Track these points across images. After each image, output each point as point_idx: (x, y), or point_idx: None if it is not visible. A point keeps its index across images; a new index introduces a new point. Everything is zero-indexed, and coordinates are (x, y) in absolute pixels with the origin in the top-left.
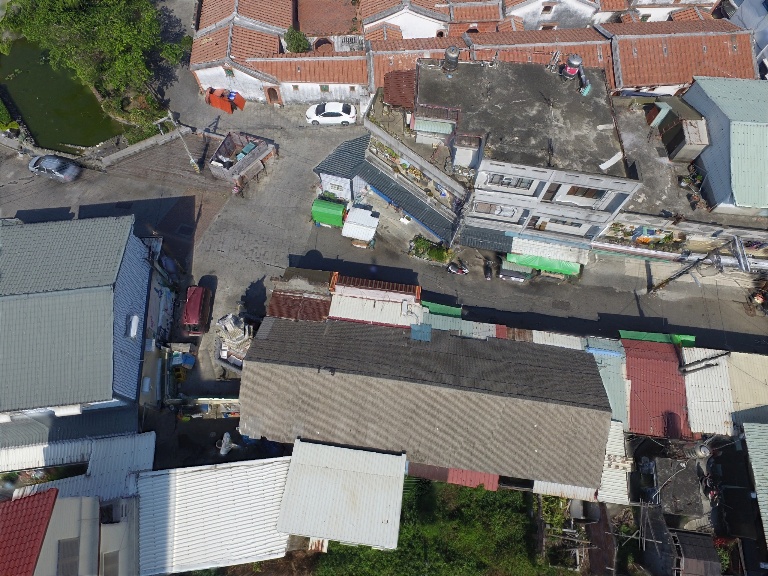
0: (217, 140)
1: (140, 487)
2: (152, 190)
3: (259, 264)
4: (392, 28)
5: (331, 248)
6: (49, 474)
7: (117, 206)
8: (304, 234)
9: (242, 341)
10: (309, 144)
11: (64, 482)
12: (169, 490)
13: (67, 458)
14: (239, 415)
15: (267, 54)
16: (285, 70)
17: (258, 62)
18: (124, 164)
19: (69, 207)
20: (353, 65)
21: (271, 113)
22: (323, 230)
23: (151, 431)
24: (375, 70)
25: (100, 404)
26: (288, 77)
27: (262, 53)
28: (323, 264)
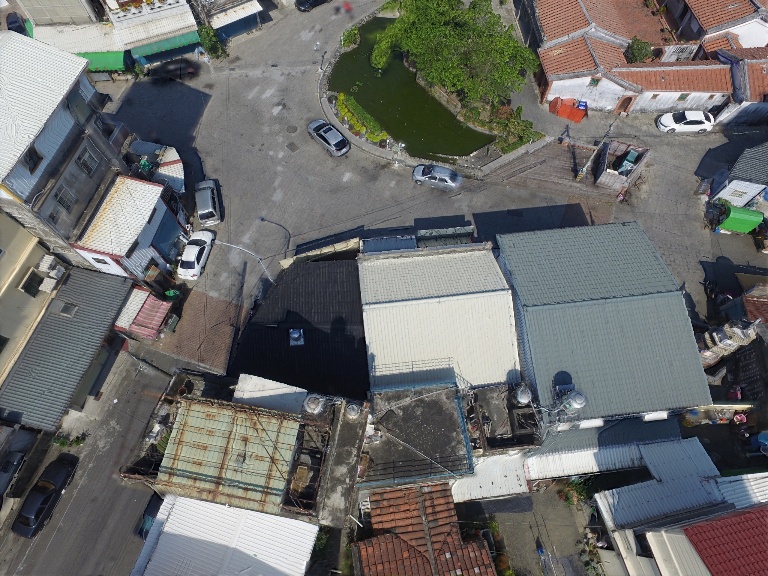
0: (582, 149)
1: (724, 493)
2: (535, 198)
3: (674, 271)
4: (732, 37)
5: (738, 254)
6: (594, 479)
7: (508, 214)
8: (705, 241)
9: (735, 347)
10: (670, 152)
11: (640, 487)
12: (751, 496)
13: (618, 463)
14: (728, 421)
15: (623, 64)
16: (649, 79)
17: (623, 72)
18: (501, 173)
19: (463, 215)
20: (716, 74)
21: (618, 122)
22: (722, 237)
23: (695, 437)
24: (749, 78)
25: (688, 409)
26: (653, 86)
27: (618, 63)
28: (738, 270)
